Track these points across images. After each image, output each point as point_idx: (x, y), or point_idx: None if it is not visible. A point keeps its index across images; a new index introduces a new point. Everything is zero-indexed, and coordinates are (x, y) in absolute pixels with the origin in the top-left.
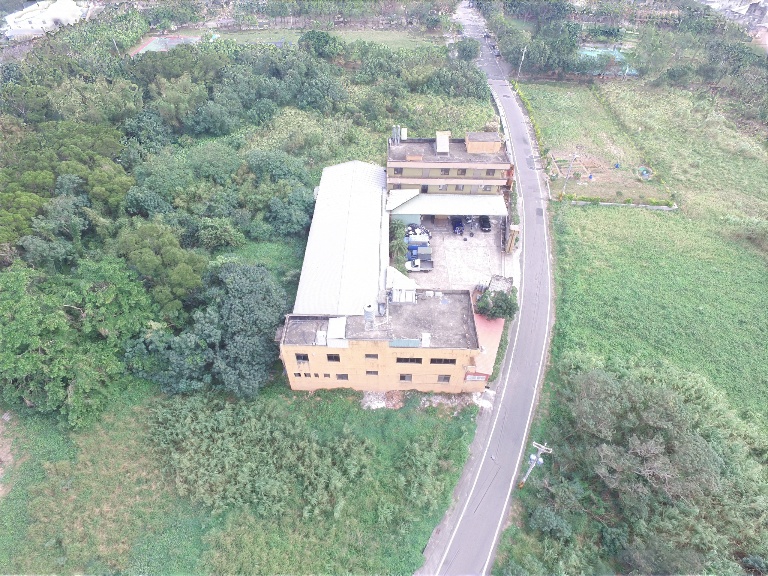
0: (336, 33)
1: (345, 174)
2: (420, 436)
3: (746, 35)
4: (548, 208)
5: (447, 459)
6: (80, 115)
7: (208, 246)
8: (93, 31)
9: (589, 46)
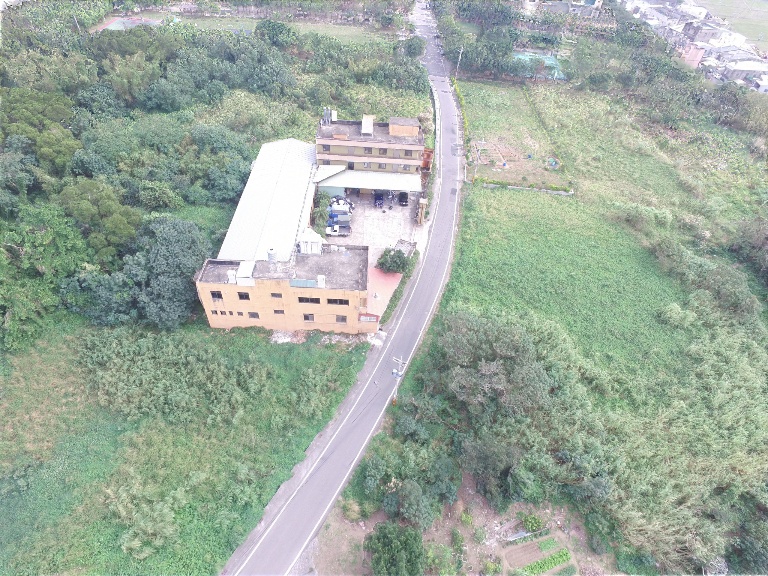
0: (295, 25)
1: (280, 149)
2: (316, 364)
3: (677, 51)
4: (462, 189)
5: None
6: (34, 84)
7: (148, 207)
8: (56, 8)
9: (529, 51)
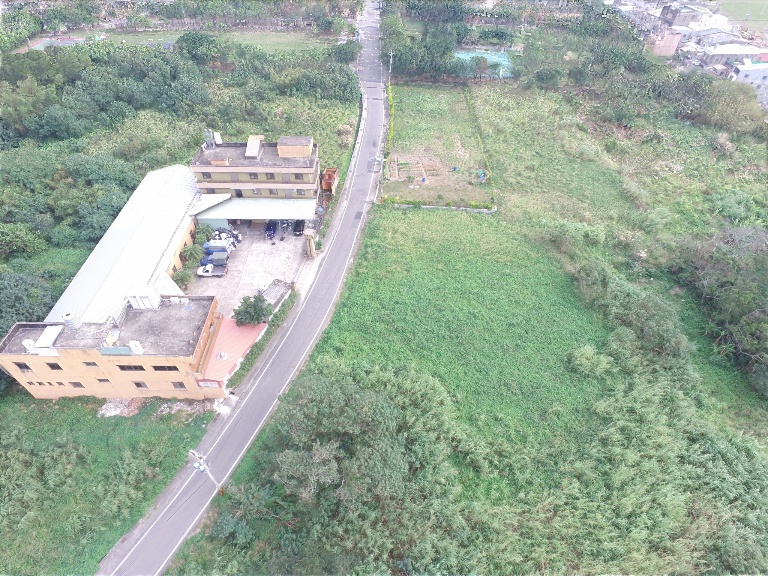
0: (231, 35)
1: (162, 178)
2: (139, 444)
3: (651, 37)
4: (368, 211)
5: (161, 467)
6: None
7: (3, 252)
8: None
9: (481, 48)
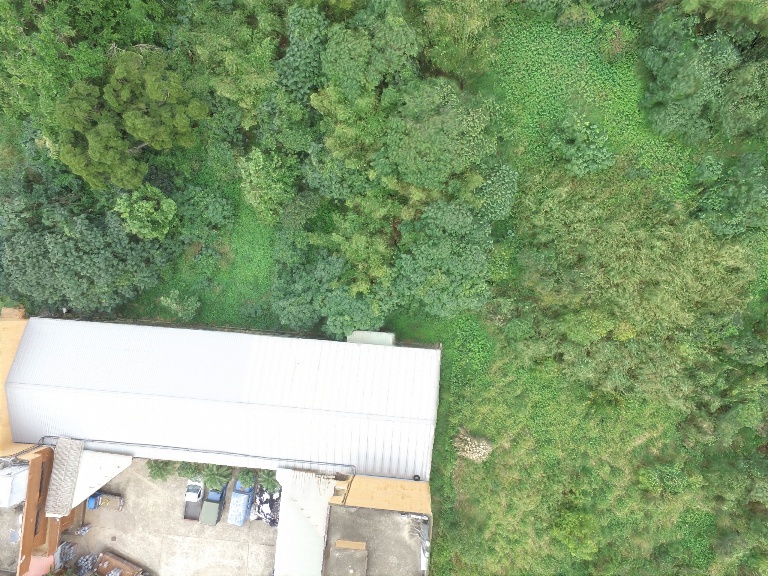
0: None
1: (388, 398)
2: None
3: None
4: None
5: None
6: None
7: None
8: None
9: None
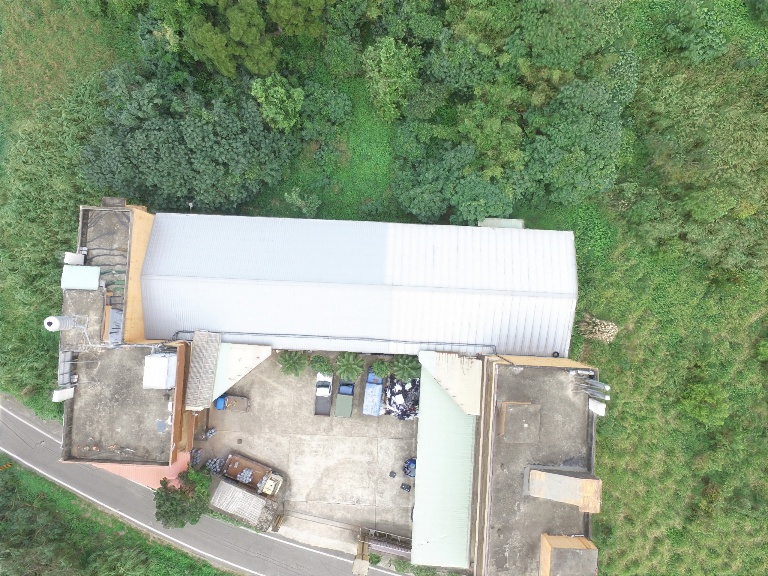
0: None
1: (529, 276)
2: None
3: None
4: None
5: (41, 394)
6: None
7: None
8: None
9: None
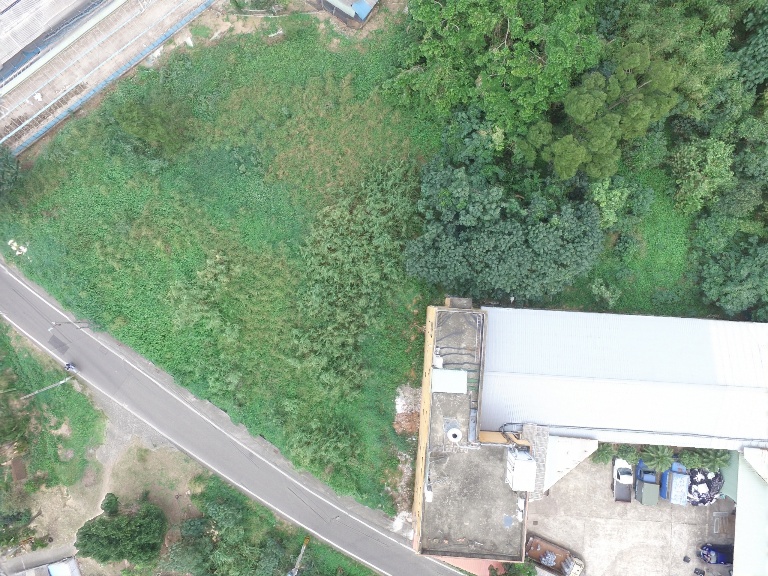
0: None
1: None
2: None
3: None
4: None
5: (338, 471)
6: None
7: None
8: None
9: None
